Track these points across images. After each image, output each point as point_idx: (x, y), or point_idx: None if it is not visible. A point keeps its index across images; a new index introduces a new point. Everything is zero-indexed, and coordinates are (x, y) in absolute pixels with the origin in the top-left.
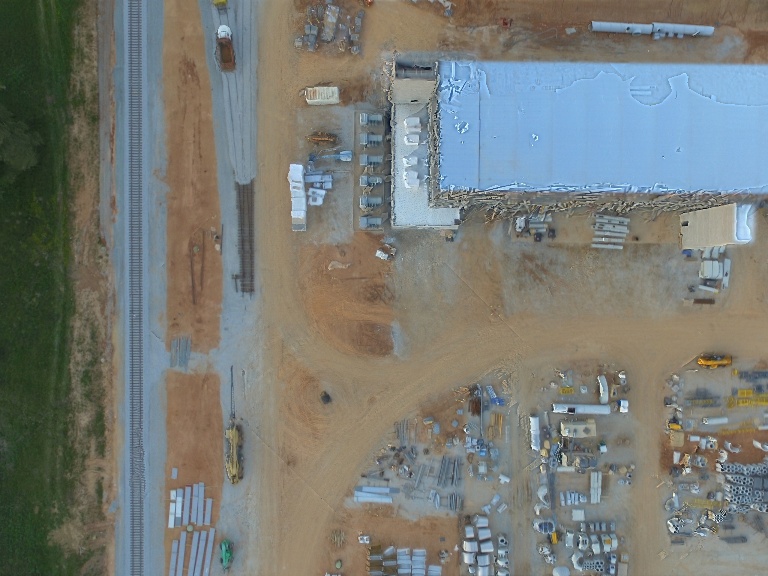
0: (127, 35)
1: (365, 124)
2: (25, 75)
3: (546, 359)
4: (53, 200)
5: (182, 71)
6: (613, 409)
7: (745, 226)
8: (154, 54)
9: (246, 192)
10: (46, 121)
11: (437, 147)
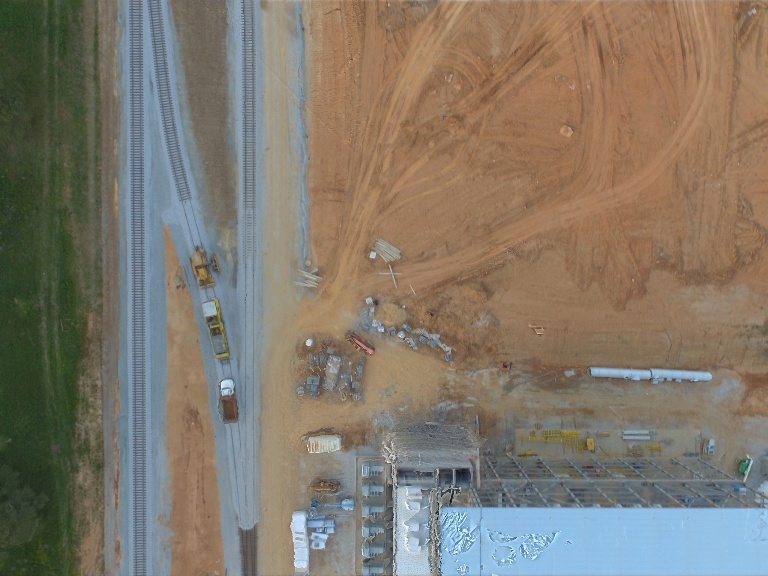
0: (131, 385)
1: (367, 476)
2: (30, 427)
3: None
4: (58, 547)
5: (186, 419)
6: None
7: None
8: (158, 402)
9: (249, 538)
10: (51, 471)
11: (438, 548)
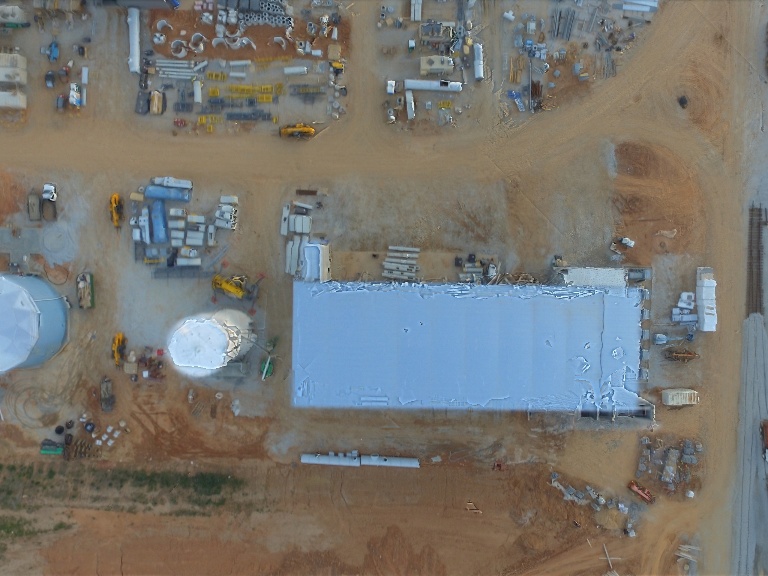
0: None
1: (643, 369)
2: None
3: (466, 137)
4: None
5: None
6: (400, 85)
7: (311, 260)
8: None
9: (755, 305)
10: None
11: None
